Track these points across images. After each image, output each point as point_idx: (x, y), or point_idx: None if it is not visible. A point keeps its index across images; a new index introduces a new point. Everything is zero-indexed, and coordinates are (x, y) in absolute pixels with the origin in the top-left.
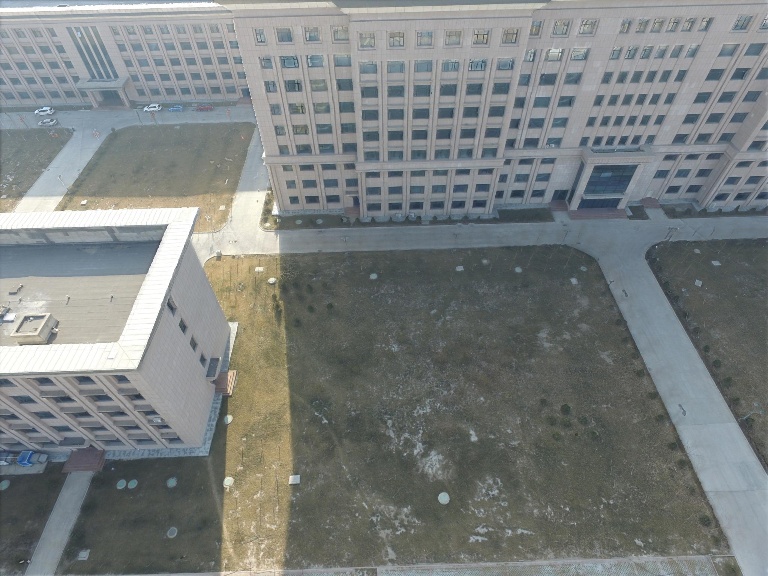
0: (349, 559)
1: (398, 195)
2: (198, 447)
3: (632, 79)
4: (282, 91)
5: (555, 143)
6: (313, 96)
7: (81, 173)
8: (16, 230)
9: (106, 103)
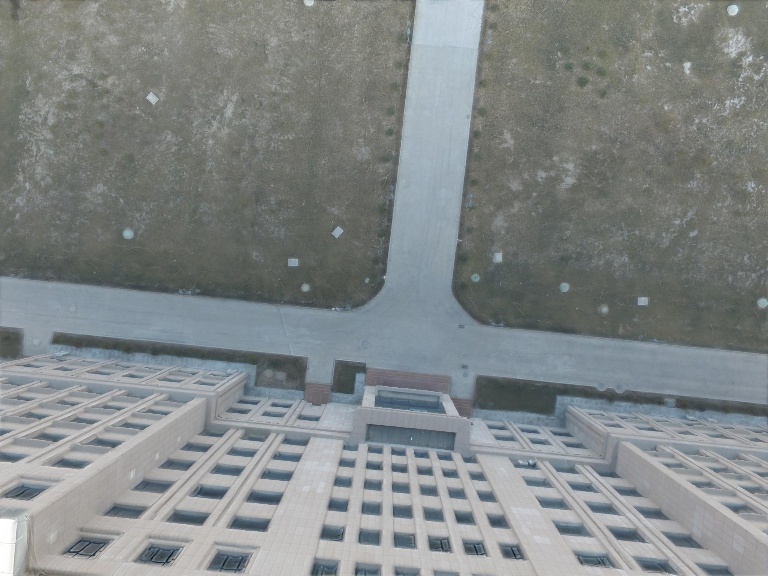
0: None
1: None
2: None
3: (439, 515)
4: None
5: (518, 466)
6: None
7: None
8: None
9: None
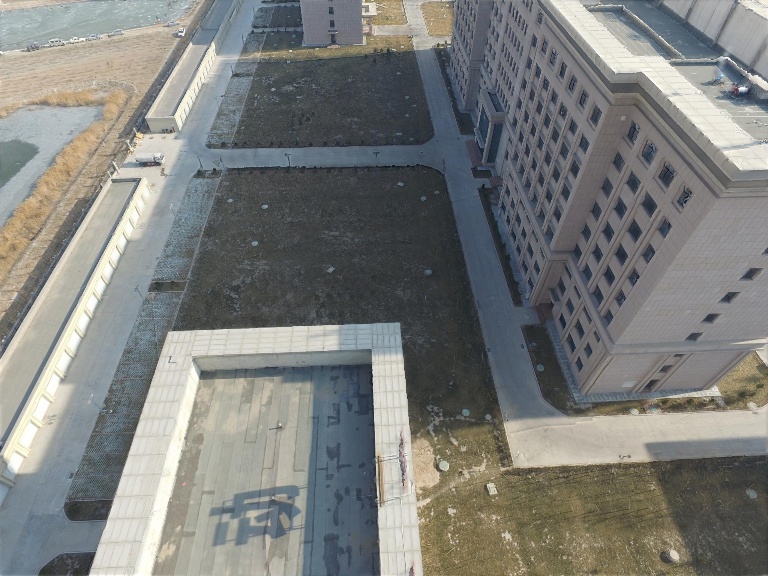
0: (257, 72)
1: None
2: None
3: None
4: None
5: None
6: None
7: None
8: None
9: None
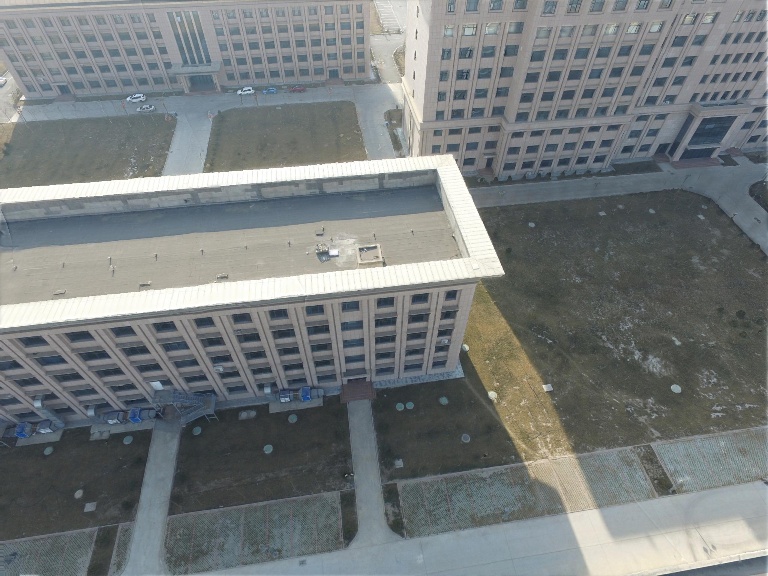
0: (624, 440)
1: (533, 154)
2: (453, 371)
3: (745, 40)
4: (455, 58)
5: (670, 100)
6: (481, 62)
7: (207, 153)
8: (298, 181)
9: (195, 89)
